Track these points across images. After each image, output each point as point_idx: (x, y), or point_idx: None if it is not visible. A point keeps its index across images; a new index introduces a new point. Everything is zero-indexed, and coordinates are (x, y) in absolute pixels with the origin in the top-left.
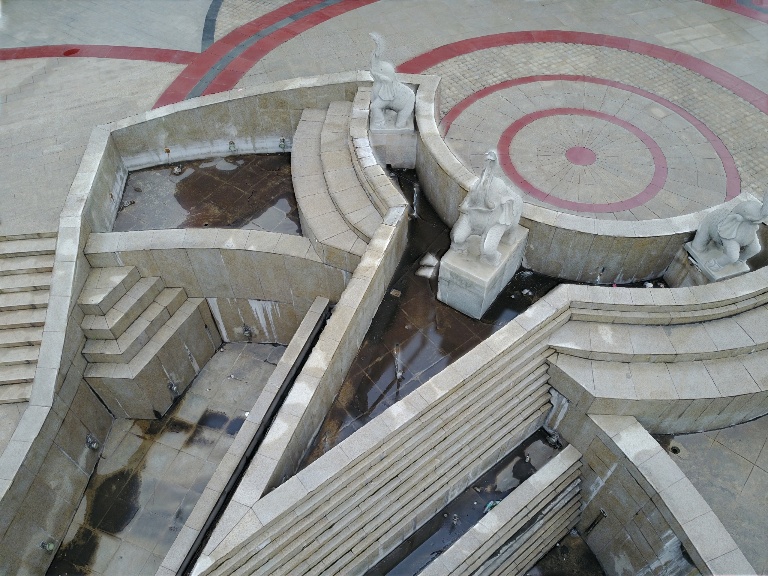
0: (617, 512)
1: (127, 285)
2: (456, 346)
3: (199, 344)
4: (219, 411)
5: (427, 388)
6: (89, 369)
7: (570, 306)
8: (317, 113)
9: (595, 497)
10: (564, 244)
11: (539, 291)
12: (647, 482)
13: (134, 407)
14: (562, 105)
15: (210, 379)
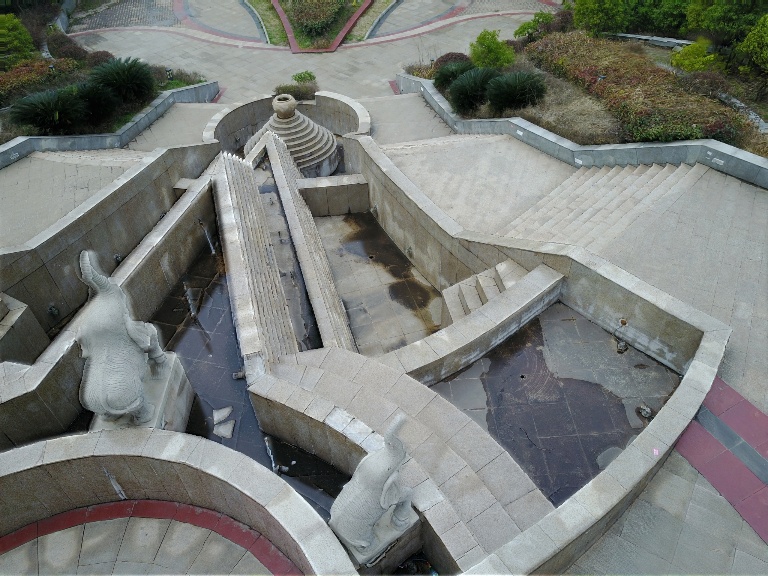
0: None
1: None
2: None
3: None
4: None
5: (137, 258)
6: None
7: None
8: (534, 521)
9: None
10: None
11: None
12: None
13: None
14: None
15: None
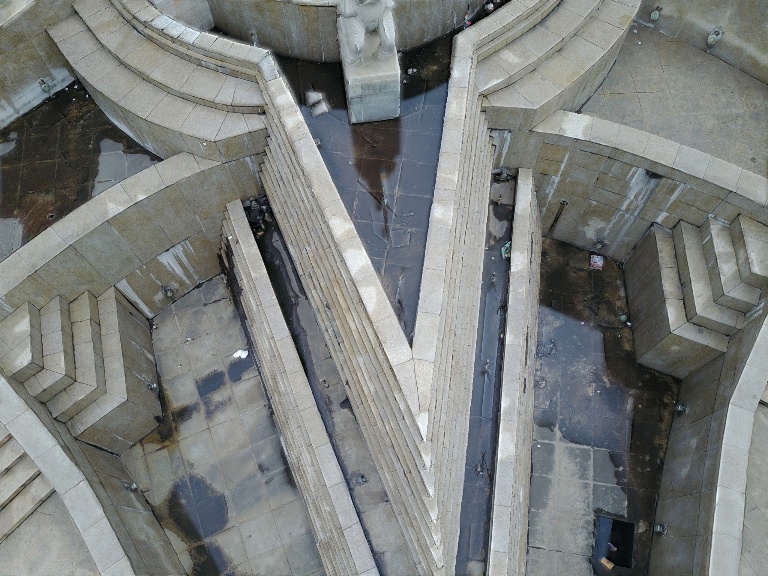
0: (578, 192)
1: (36, 326)
2: (402, 149)
3: (138, 334)
4: (208, 373)
5: (442, 180)
6: (72, 428)
7: (473, 50)
8: (66, 25)
9: (553, 196)
10: (421, 5)
11: (419, 64)
12: (603, 146)
13: (134, 430)
14: None
15: (171, 357)
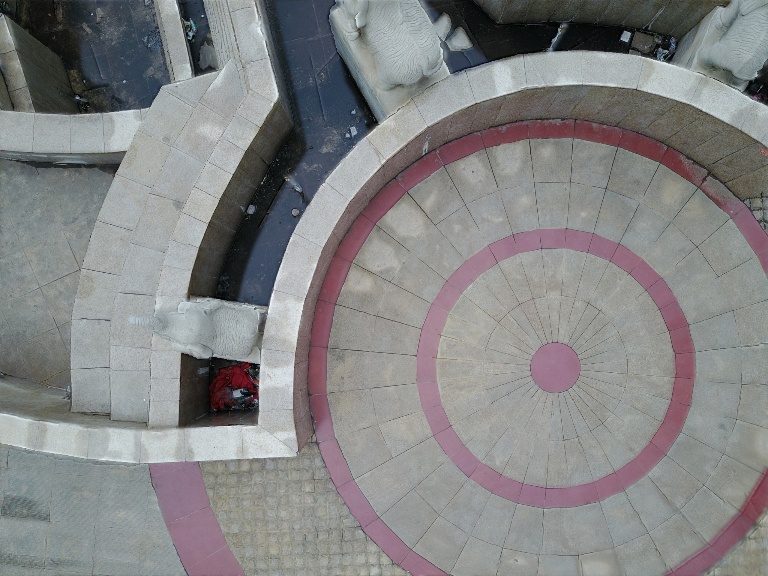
0: None
1: None
2: (317, 7)
3: None
4: None
5: None
6: None
7: None
8: None
9: None
10: None
11: (346, 149)
12: None
13: None
14: (693, 426)
15: None
